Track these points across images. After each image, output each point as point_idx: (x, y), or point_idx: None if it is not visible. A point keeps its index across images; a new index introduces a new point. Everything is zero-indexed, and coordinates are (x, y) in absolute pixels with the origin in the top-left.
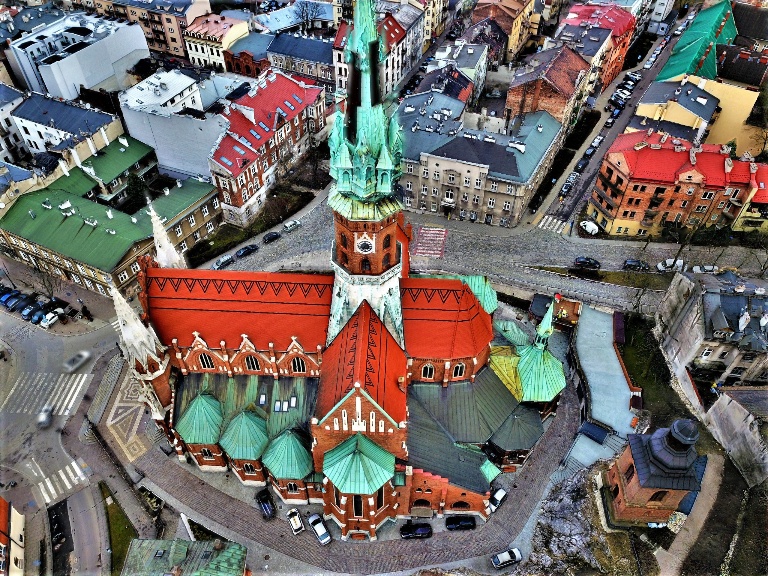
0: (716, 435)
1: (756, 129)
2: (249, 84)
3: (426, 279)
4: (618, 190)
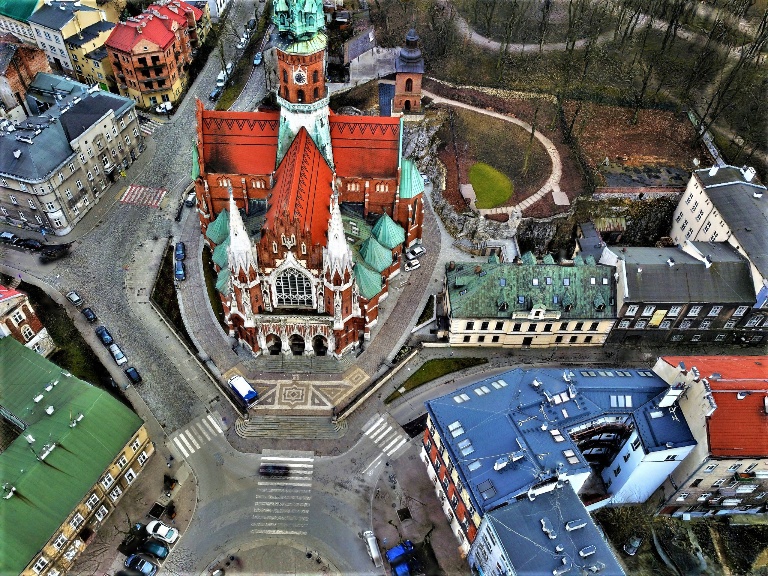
0: (365, 81)
1: (110, 4)
2: None
3: None
4: (161, 65)
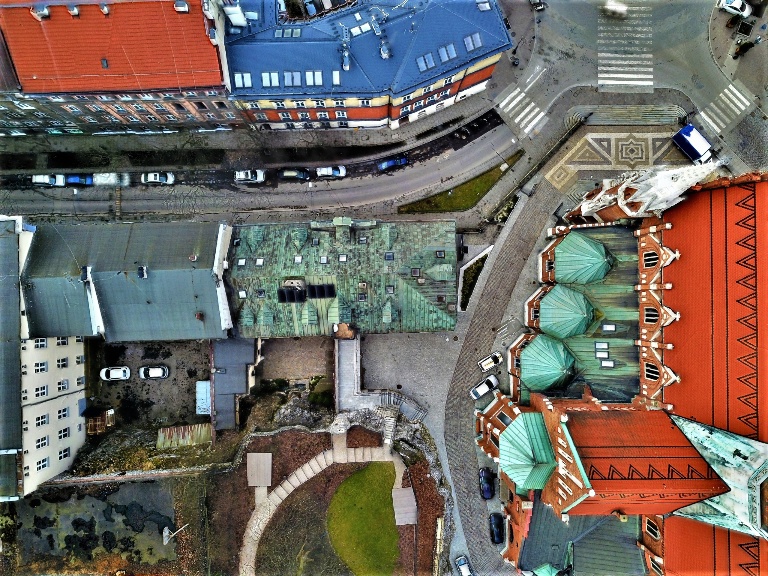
0: None
1: None
2: None
3: None
4: None
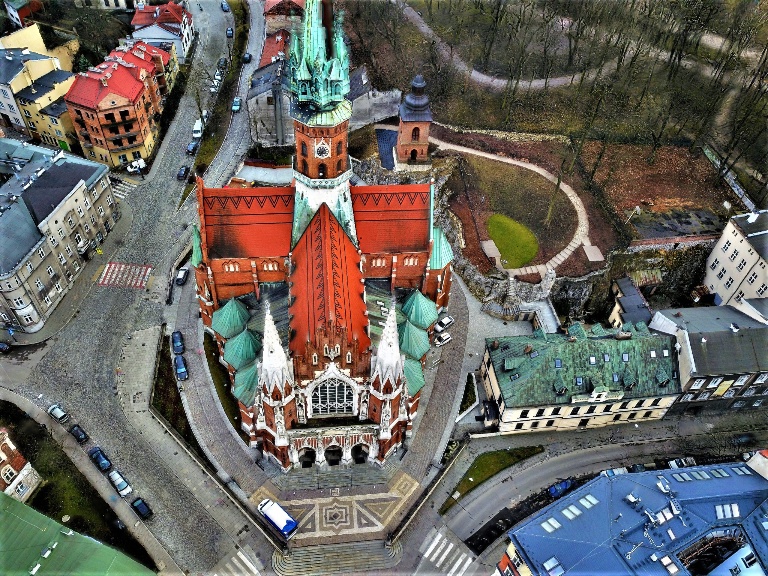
0: (359, 126)
1: (62, 48)
2: None
3: None
4: (131, 120)
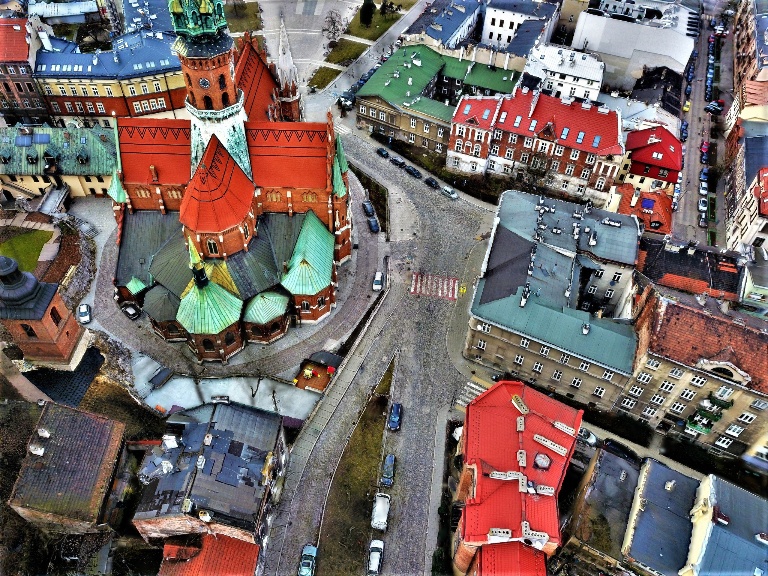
0: None
1: None
2: (600, 105)
3: (209, 146)
4: None
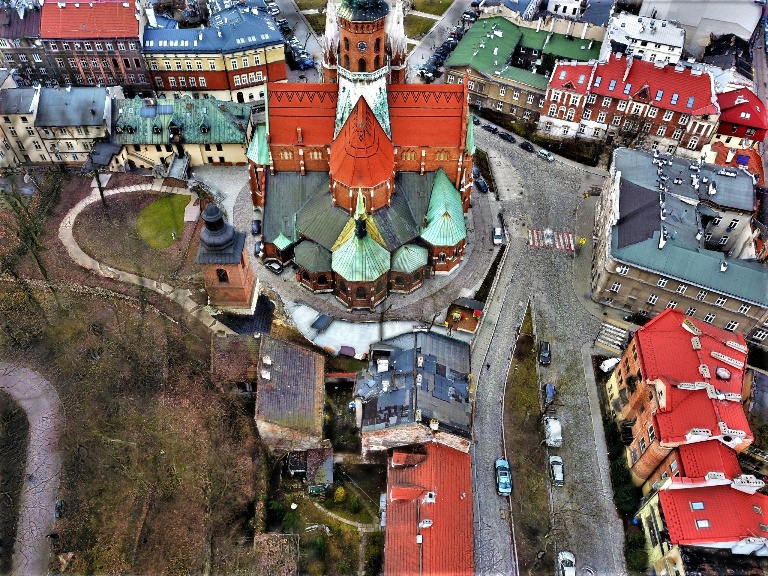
0: None
1: None
2: None
3: (361, 107)
4: None
